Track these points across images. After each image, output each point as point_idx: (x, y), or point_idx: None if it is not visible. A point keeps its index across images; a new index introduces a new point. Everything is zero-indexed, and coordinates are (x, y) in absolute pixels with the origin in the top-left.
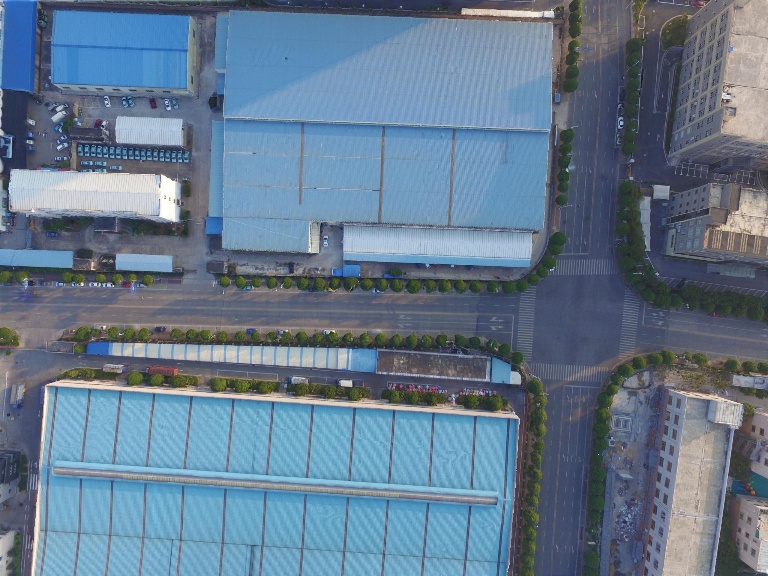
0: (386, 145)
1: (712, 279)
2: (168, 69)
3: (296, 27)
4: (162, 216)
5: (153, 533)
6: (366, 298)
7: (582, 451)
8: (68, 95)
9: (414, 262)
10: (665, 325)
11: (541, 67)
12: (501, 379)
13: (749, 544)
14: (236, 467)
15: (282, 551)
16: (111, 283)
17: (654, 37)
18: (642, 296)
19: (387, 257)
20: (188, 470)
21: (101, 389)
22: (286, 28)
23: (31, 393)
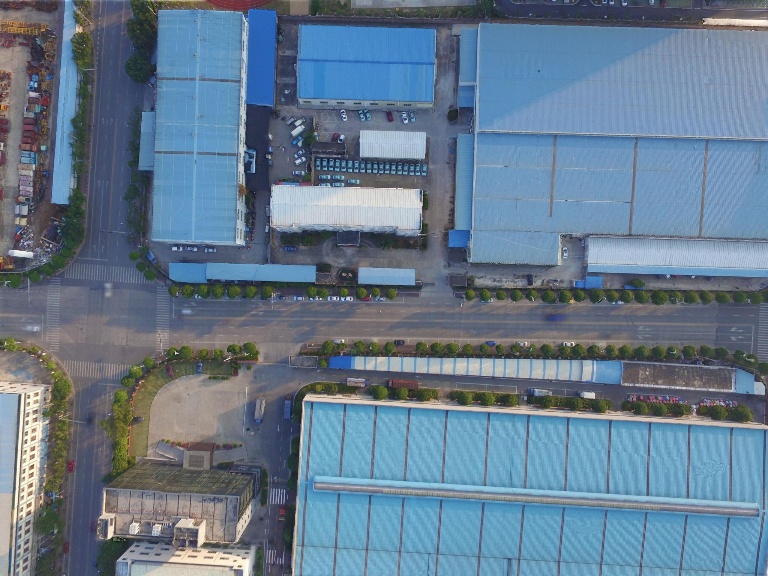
0: (638, 157)
1: None
2: (415, 83)
3: (547, 39)
4: None
5: (410, 547)
6: (605, 309)
7: None
8: (304, 109)
9: (658, 273)
10: None
11: None
12: (745, 390)
13: None
14: (494, 481)
15: (539, 564)
16: (350, 297)
17: None
18: None
19: (631, 268)
20: (447, 484)
21: (358, 404)
22: (537, 40)
23: (270, 407)
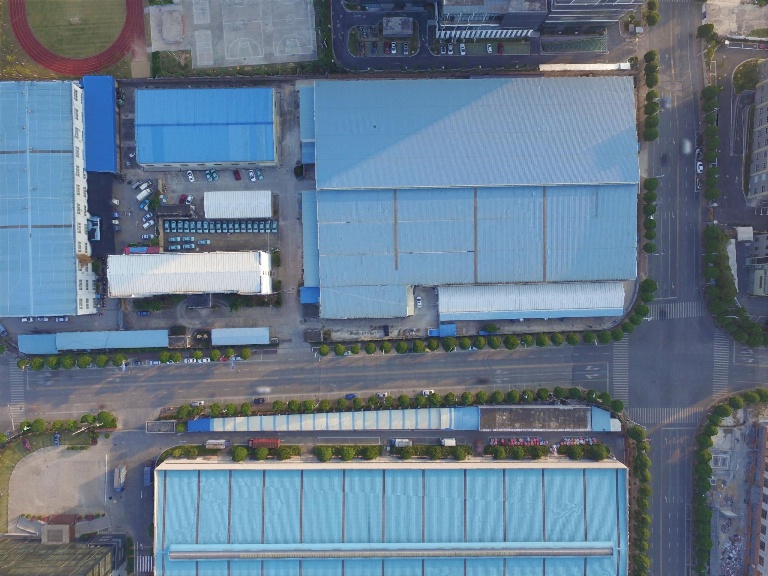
0: (478, 206)
1: None
2: (255, 142)
3: (382, 94)
4: (263, 292)
5: None
6: (462, 356)
7: (683, 491)
8: (150, 172)
9: (509, 318)
10: (755, 362)
11: (625, 121)
12: (601, 427)
13: None
14: (352, 537)
15: None
16: (207, 358)
17: (726, 82)
18: (734, 337)
19: (483, 315)
20: (304, 544)
21: (211, 469)
22: (372, 96)
23: (132, 474)
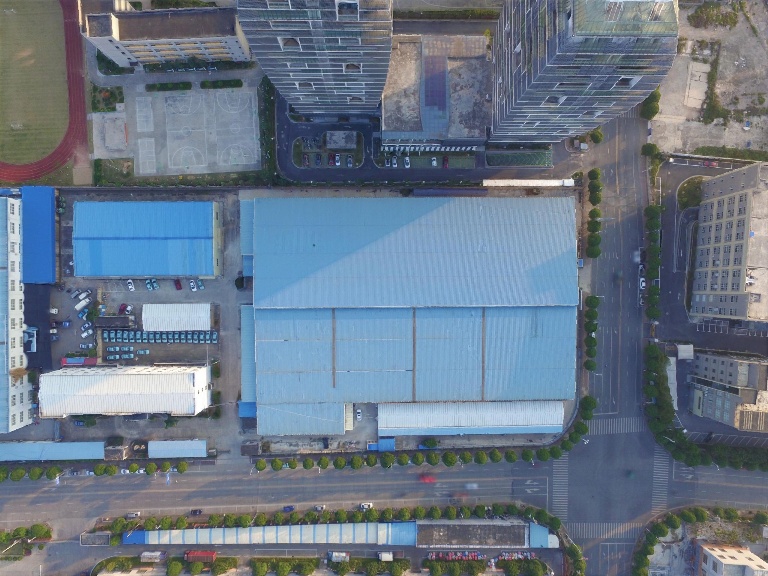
0: (417, 326)
1: (737, 431)
2: (194, 257)
3: (322, 212)
4: None
5: None
6: (402, 468)
7: None
8: (90, 280)
9: (449, 434)
10: (695, 478)
11: (566, 242)
12: (539, 543)
13: None
14: None
15: None
16: (144, 469)
17: (671, 198)
18: (672, 456)
19: (422, 431)
20: None
21: None
22: (312, 214)
23: None
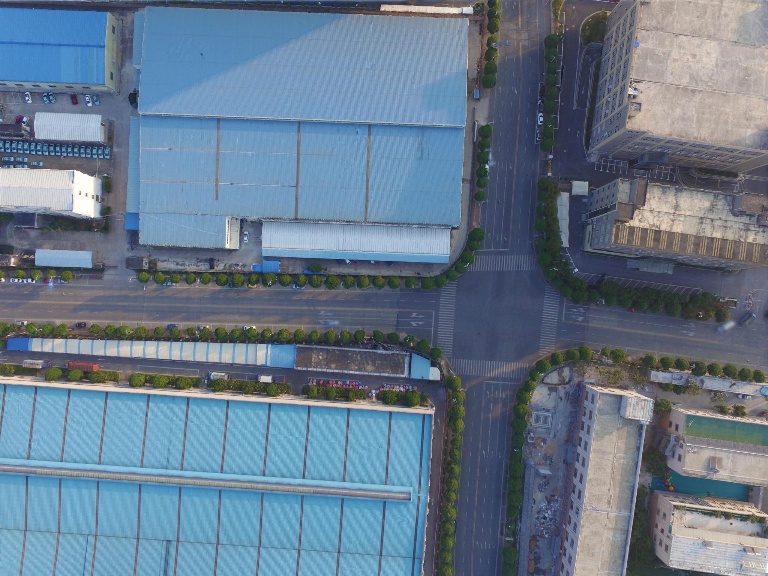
0: (302, 141)
1: (632, 275)
2: (86, 65)
3: (212, 23)
4: (76, 211)
5: (68, 528)
6: (287, 294)
7: (502, 447)
8: None
9: (333, 258)
10: (585, 321)
11: (456, 63)
12: (420, 375)
13: (663, 540)
14: (151, 462)
15: (197, 546)
16: None
17: (574, 33)
18: (560, 292)
19: (306, 253)
20: (102, 465)
21: (16, 384)
22: (202, 24)
23: None
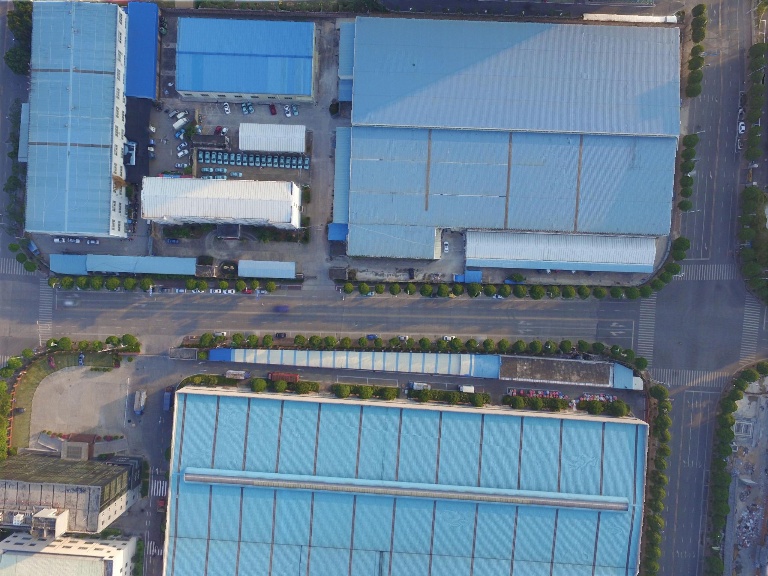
0: (513, 151)
1: None
2: (293, 76)
3: (423, 33)
4: (292, 223)
5: (282, 539)
6: (486, 304)
7: (703, 456)
8: (188, 102)
9: (537, 268)
10: None
11: (669, 72)
12: (623, 385)
13: None
14: (366, 473)
15: (411, 557)
16: (232, 289)
17: None
18: (766, 301)
19: (510, 263)
20: (318, 476)
21: (231, 396)
22: (413, 34)
23: (152, 399)
